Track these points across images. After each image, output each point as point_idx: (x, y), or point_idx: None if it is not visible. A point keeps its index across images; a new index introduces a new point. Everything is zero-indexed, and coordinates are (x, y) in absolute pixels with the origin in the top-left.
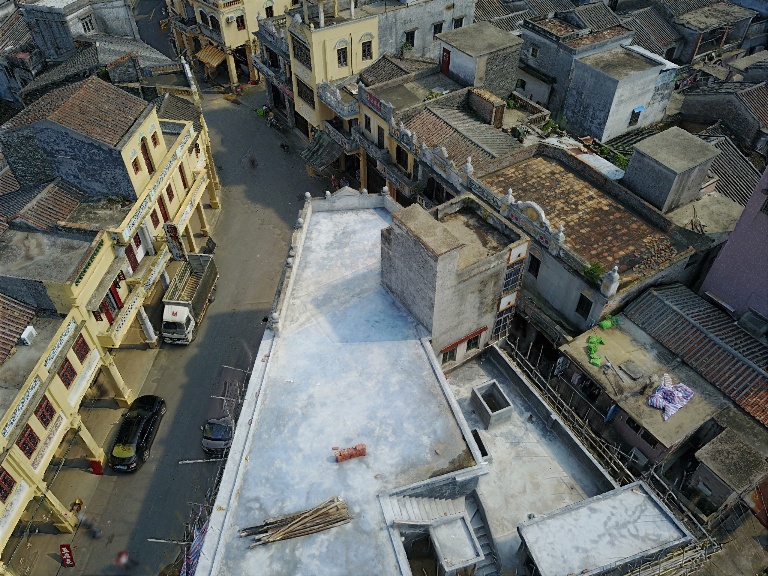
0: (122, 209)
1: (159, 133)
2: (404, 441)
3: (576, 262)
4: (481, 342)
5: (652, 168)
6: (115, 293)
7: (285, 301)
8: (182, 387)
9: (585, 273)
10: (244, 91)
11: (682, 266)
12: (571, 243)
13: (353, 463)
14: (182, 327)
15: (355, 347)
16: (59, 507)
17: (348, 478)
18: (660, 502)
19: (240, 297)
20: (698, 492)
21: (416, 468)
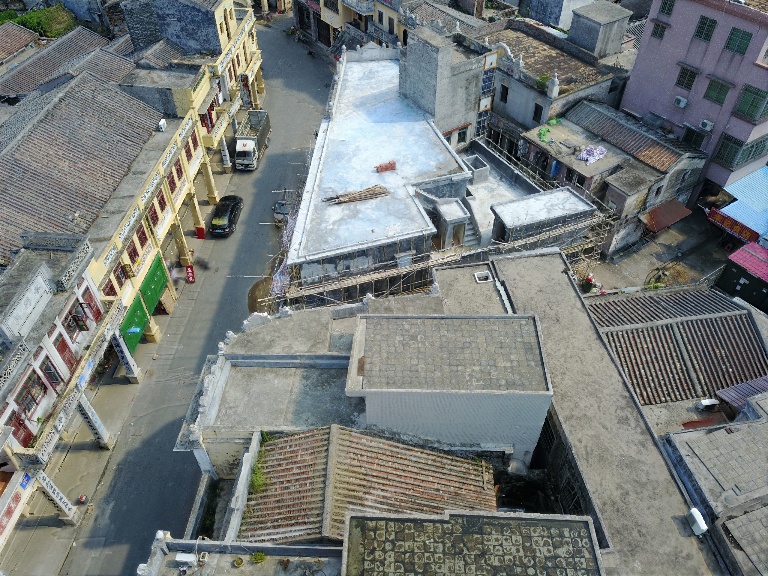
0: (212, 59)
1: (233, 11)
2: (419, 164)
3: (531, 79)
4: (468, 137)
5: (585, 25)
6: (210, 114)
7: (335, 101)
8: (253, 194)
9: (538, 87)
10: (273, 18)
11: (606, 90)
12: None
13: (388, 173)
14: (250, 156)
15: (384, 125)
16: None
17: (385, 179)
18: None
19: (288, 144)
20: None
21: (427, 174)
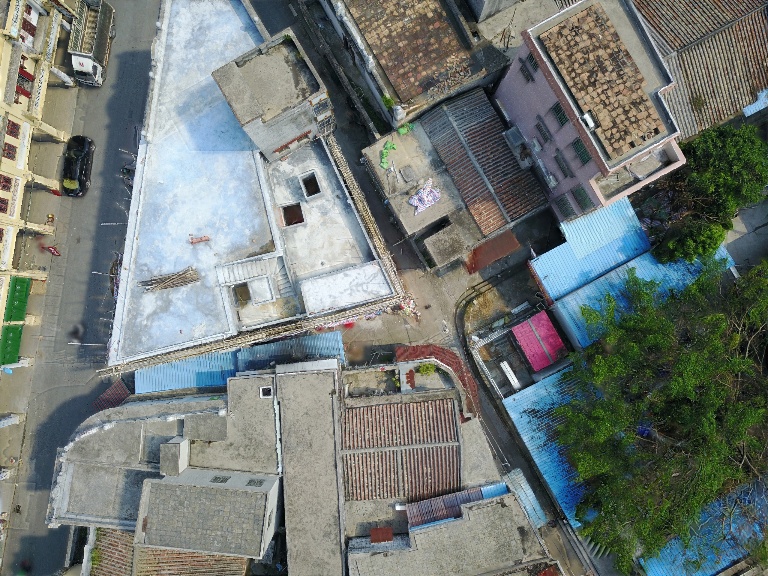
0: None
1: None
2: (234, 232)
3: None
4: (310, 136)
5: None
6: (24, 73)
7: (152, 114)
8: (103, 126)
9: None
10: None
11: None
12: (386, 59)
13: (202, 245)
14: (91, 74)
15: (206, 155)
16: (38, 228)
17: (198, 255)
18: (386, 273)
19: (138, 33)
20: (430, 254)
21: (239, 251)
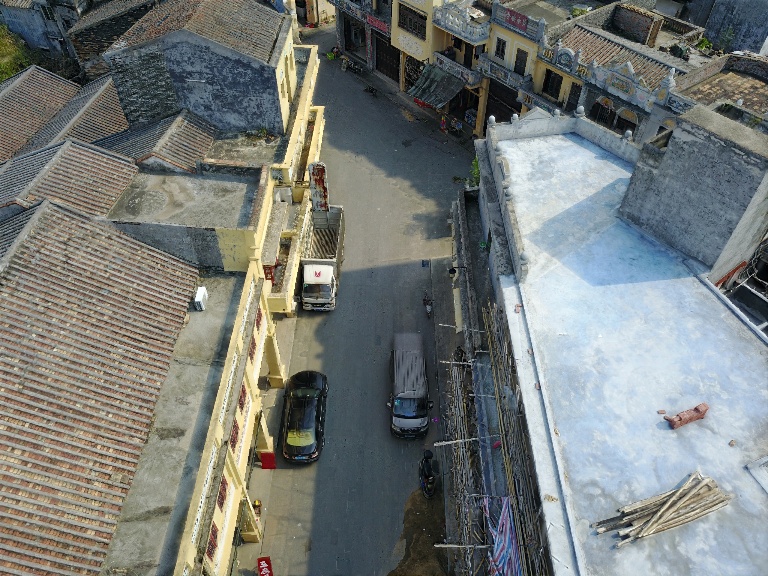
0: (268, 145)
1: (293, 55)
2: (741, 398)
3: None
4: (730, 281)
5: None
6: None
7: None
8: (338, 360)
9: None
10: (304, 35)
11: None
12: None
13: (693, 429)
14: (326, 290)
15: (622, 289)
16: (253, 511)
17: (696, 448)
18: None
19: (373, 254)
20: None
21: None
